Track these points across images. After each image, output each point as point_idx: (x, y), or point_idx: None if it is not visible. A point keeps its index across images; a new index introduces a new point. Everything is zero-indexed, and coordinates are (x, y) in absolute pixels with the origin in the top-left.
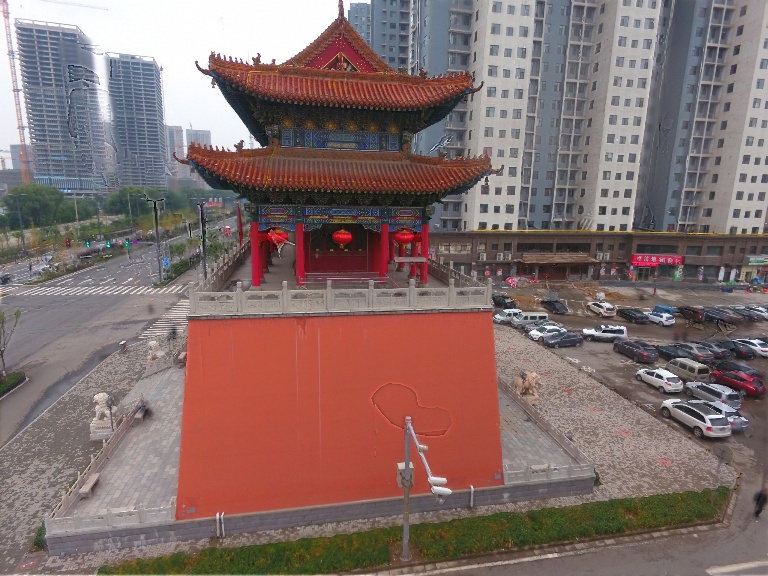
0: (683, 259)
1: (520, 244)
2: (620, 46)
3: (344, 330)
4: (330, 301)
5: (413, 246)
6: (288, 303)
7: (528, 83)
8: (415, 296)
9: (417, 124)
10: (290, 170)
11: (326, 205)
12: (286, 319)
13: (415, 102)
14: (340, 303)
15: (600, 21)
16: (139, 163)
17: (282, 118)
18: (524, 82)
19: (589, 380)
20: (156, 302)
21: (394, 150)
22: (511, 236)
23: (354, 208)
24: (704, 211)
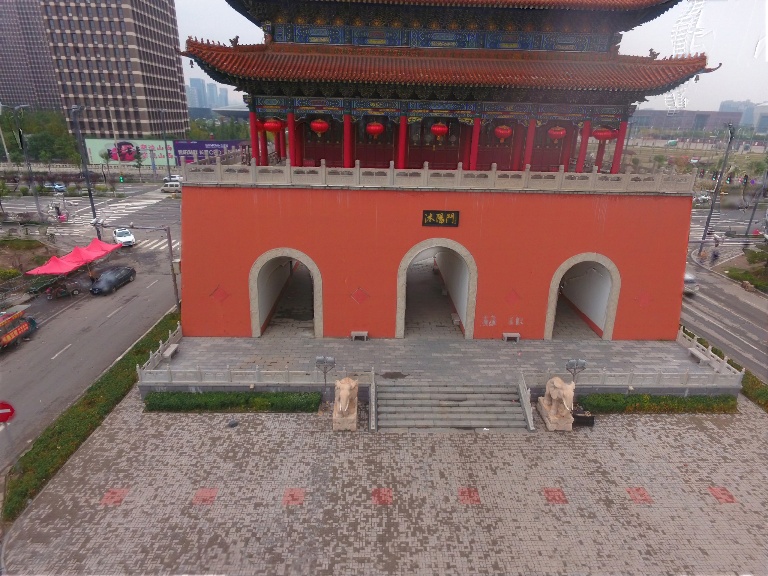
0: None
1: None
2: None
3: None
4: None
5: None
6: None
7: None
8: None
9: None
10: None
11: None
12: None
13: None
14: None
15: None
16: None
17: None
18: None
19: (433, 570)
20: None
21: None
22: None
23: None
24: None
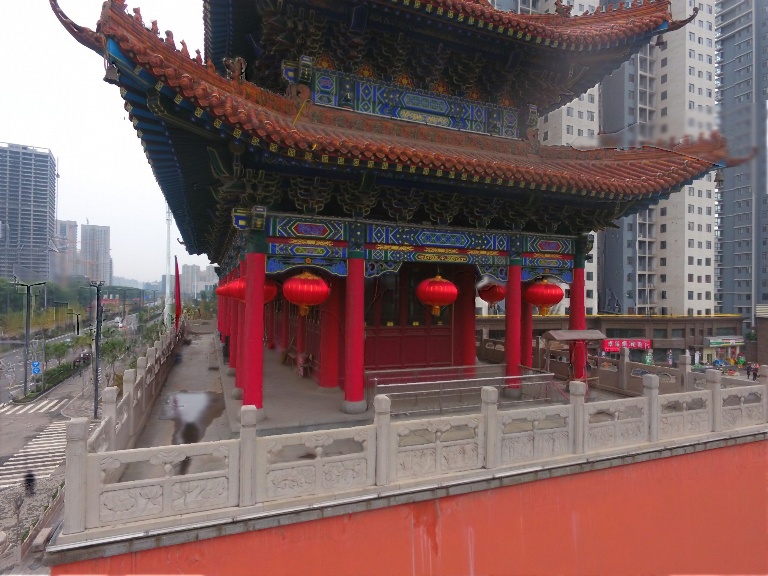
0: (651, 343)
1: (492, 331)
2: (568, 134)
3: (528, 523)
4: (494, 444)
5: (526, 315)
6: (389, 461)
7: None
8: (658, 414)
9: (552, 94)
10: (346, 139)
11: (411, 223)
12: (386, 512)
13: (582, 34)
14: (514, 447)
15: None
16: (11, 236)
17: (316, 51)
18: None
19: None
20: (12, 428)
21: (512, 137)
22: (482, 322)
23: (463, 232)
24: (663, 293)
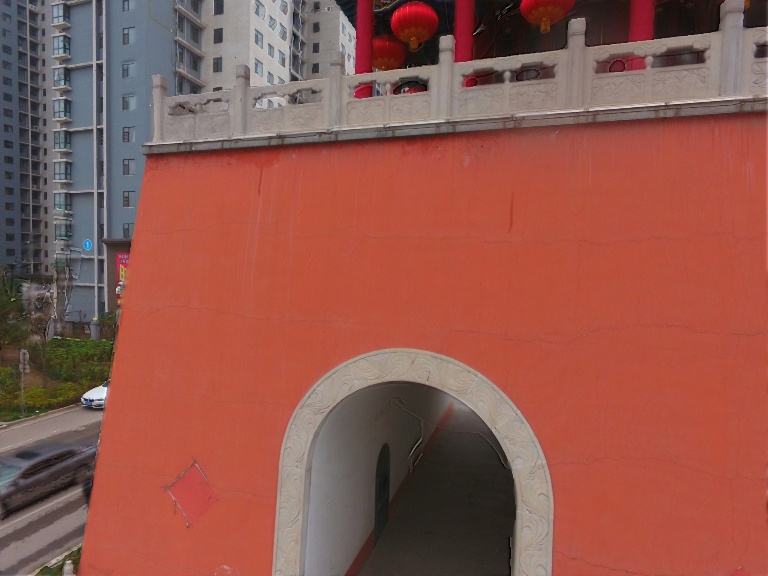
0: None
1: None
2: None
3: None
4: None
5: None
6: None
7: (289, 49)
8: None
9: None
10: None
11: None
12: None
13: None
14: None
15: (315, 19)
16: None
17: None
18: (285, 46)
19: None
20: None
21: None
22: None
23: None
24: None
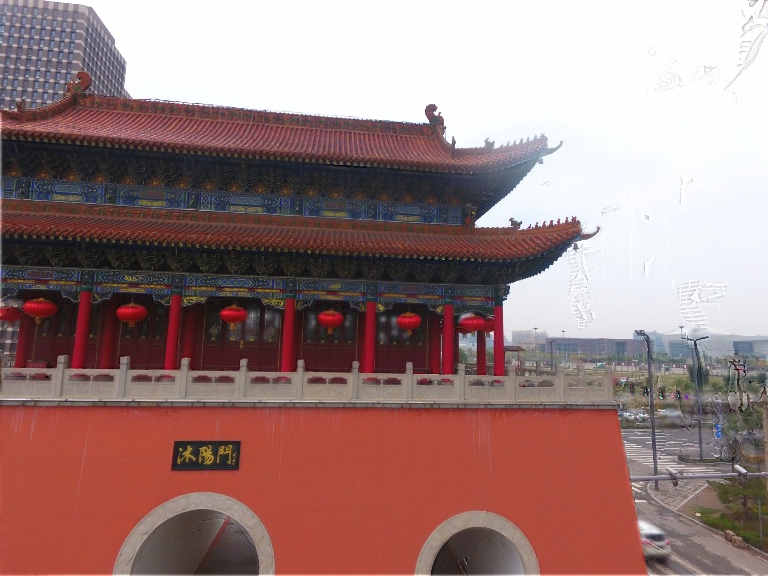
0: None
1: None
2: None
3: None
4: None
5: None
6: None
7: None
8: None
9: None
10: None
11: None
12: None
13: None
14: None
15: None
16: None
17: None
18: None
19: None
20: None
21: None
22: None
23: None
24: None
